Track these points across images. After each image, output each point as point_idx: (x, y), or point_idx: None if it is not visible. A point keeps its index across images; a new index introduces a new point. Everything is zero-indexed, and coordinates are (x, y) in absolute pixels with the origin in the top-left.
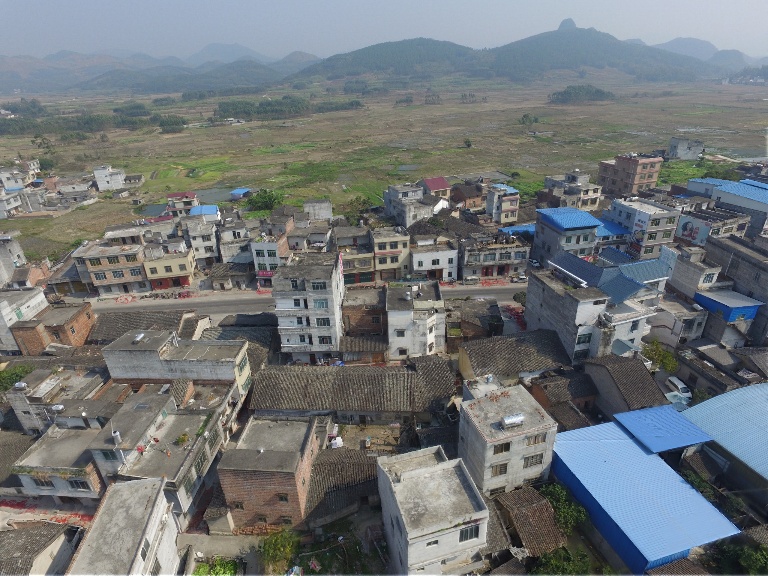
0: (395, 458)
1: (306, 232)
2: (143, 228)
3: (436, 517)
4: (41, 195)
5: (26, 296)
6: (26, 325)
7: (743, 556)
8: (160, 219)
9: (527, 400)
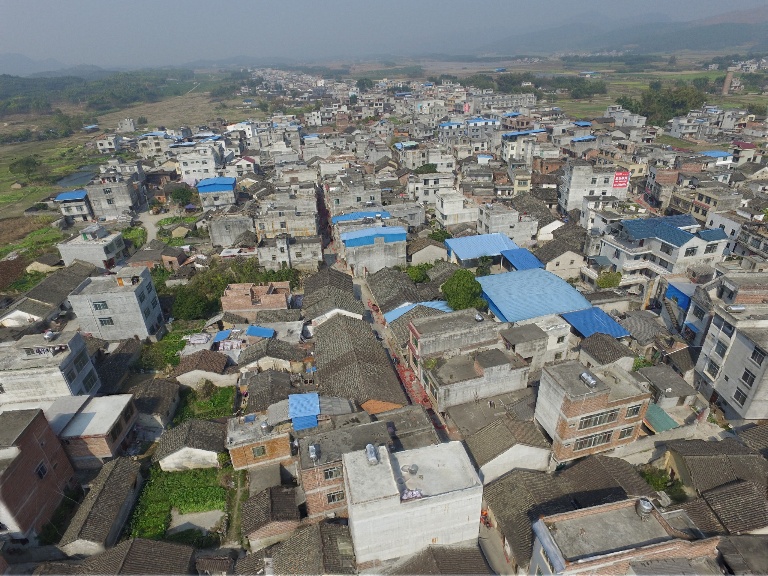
0: (474, 202)
1: (694, 175)
2: (662, 150)
3: (443, 196)
4: (711, 129)
5: (550, 148)
6: (536, 157)
7: None
8: (681, 149)
9: None
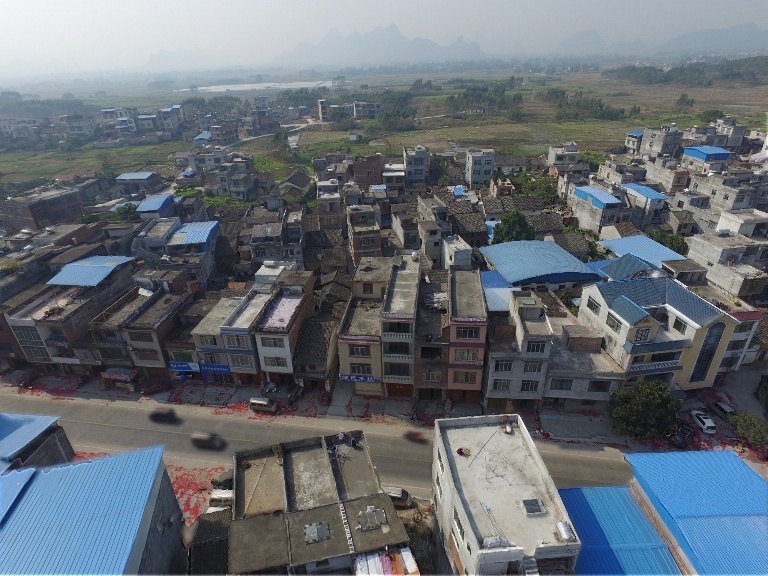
0: None
1: None
2: None
3: None
4: None
5: None
6: None
7: (596, 244)
8: None
9: (716, 242)
